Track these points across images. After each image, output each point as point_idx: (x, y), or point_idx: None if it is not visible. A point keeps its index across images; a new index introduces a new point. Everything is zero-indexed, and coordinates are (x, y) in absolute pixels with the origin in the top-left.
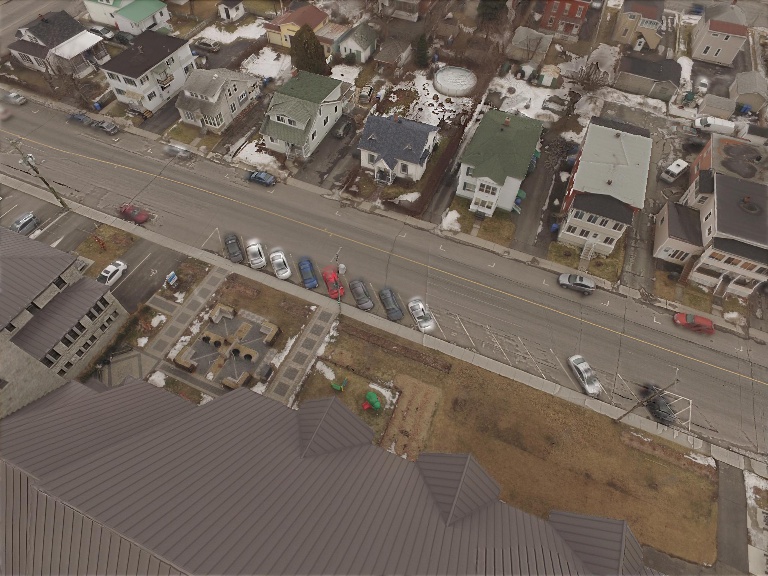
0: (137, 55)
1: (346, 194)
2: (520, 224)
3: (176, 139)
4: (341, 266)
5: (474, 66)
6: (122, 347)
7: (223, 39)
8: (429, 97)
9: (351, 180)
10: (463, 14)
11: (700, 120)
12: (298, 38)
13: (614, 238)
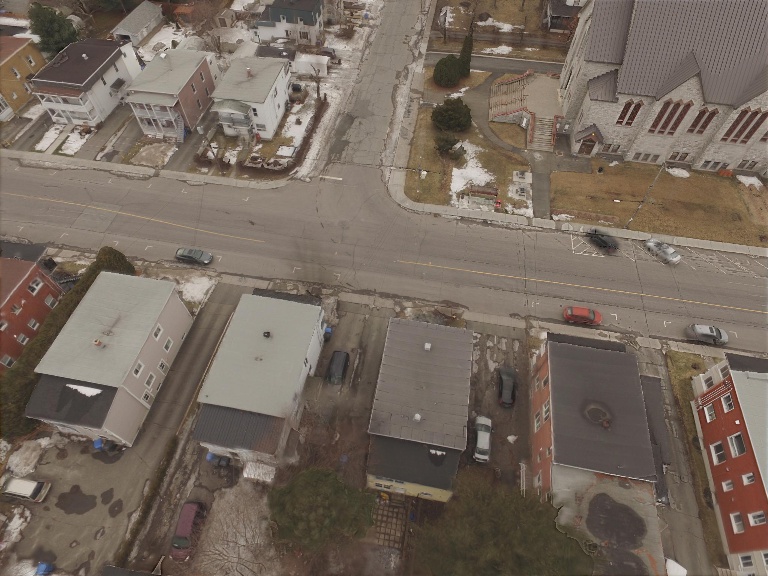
0: None
1: None
2: None
3: None
4: None
5: None
6: None
7: None
8: None
9: None
10: None
11: None
12: None
13: None
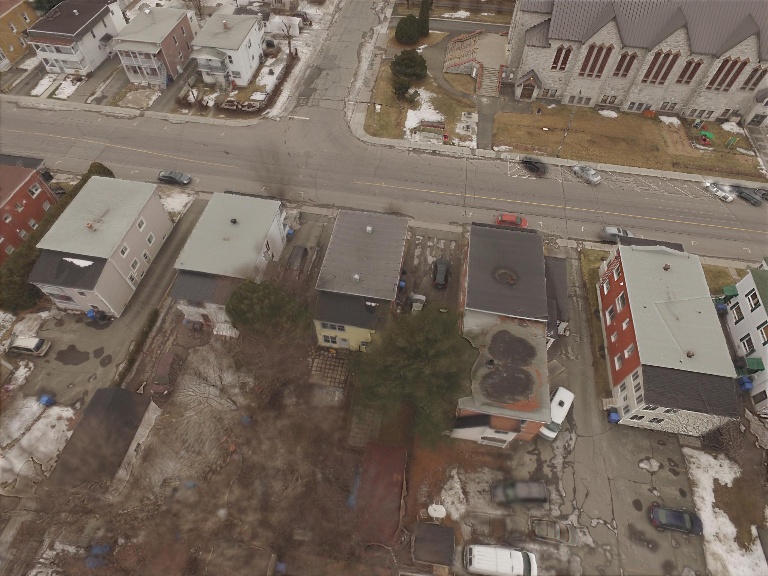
0: None
1: None
2: None
3: None
4: None
5: None
6: None
7: None
8: None
9: None
10: None
11: (532, 571)
12: None
13: None
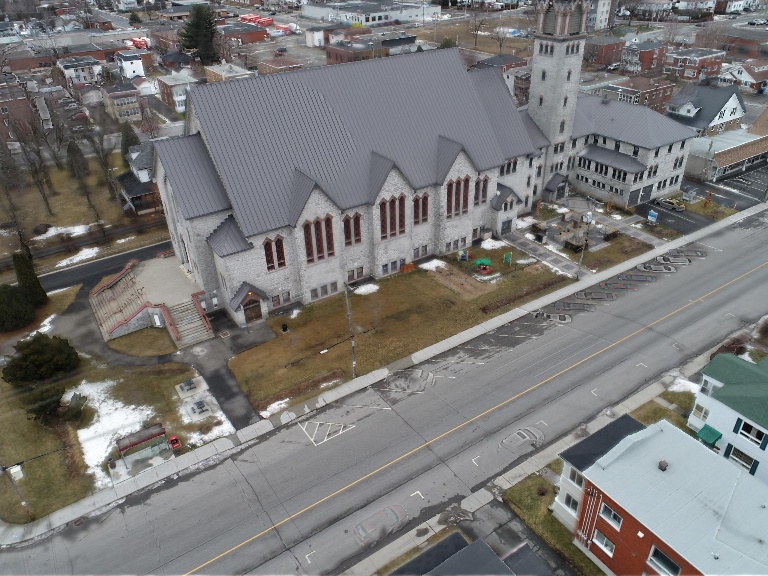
0: None
1: (764, 323)
2: None
3: None
4: None
5: None
6: None
7: None
8: None
9: None
10: None
11: None
12: None
13: None
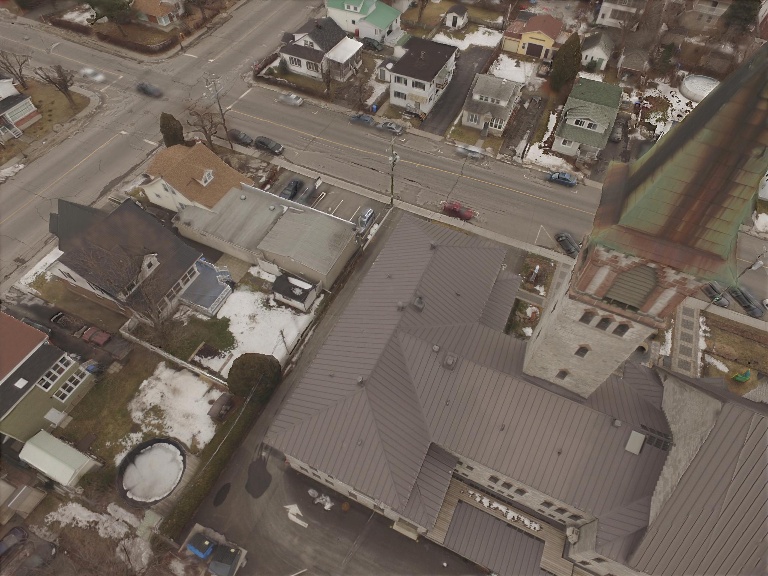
0: (418, 60)
1: None
2: None
3: (460, 140)
4: (761, 262)
5: (715, 75)
6: (514, 336)
7: (457, 46)
8: (682, 104)
9: None
10: (678, 24)
11: None
12: (571, 46)
13: None
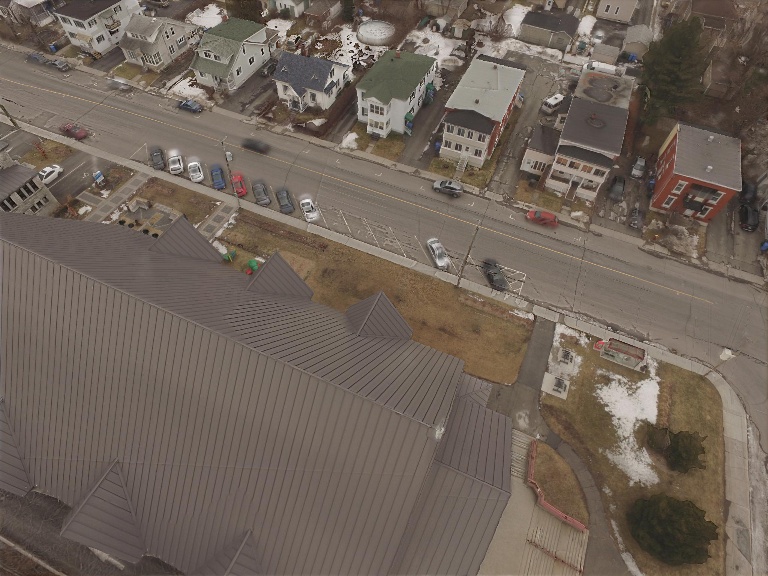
0: (88, 3)
1: (261, 119)
2: (410, 144)
3: (120, 76)
4: (227, 153)
5: (395, 20)
6: None
7: None
8: (351, 45)
9: (268, 109)
10: None
11: (587, 65)
12: None
13: (481, 150)
